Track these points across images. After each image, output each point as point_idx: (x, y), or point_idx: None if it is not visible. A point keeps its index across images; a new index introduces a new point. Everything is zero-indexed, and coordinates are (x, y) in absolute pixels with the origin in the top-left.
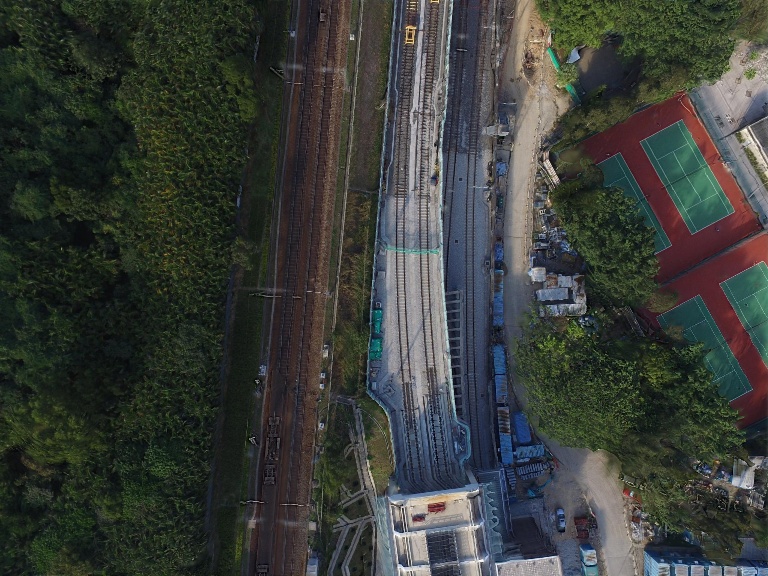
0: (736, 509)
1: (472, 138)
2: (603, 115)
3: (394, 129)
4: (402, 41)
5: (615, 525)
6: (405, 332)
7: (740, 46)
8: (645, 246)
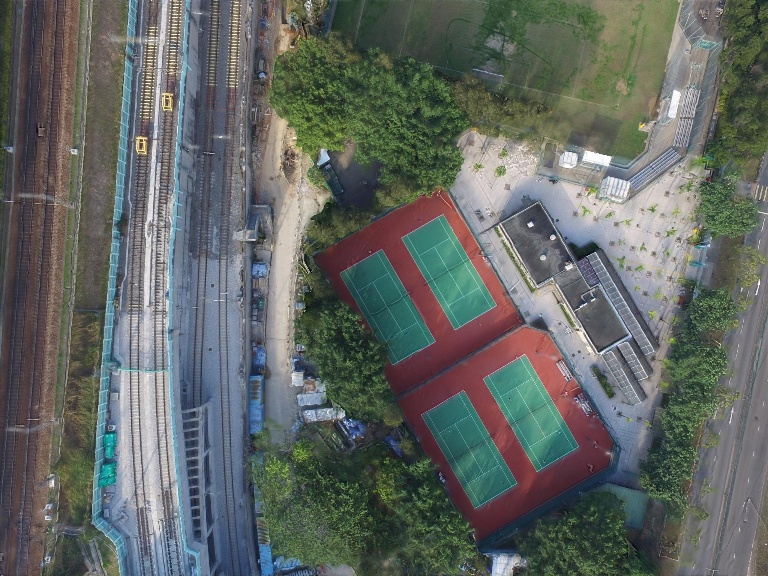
0: None
1: (222, 243)
2: (329, 229)
3: (128, 243)
4: (135, 151)
5: None
6: (139, 455)
7: (497, 140)
8: (365, 365)
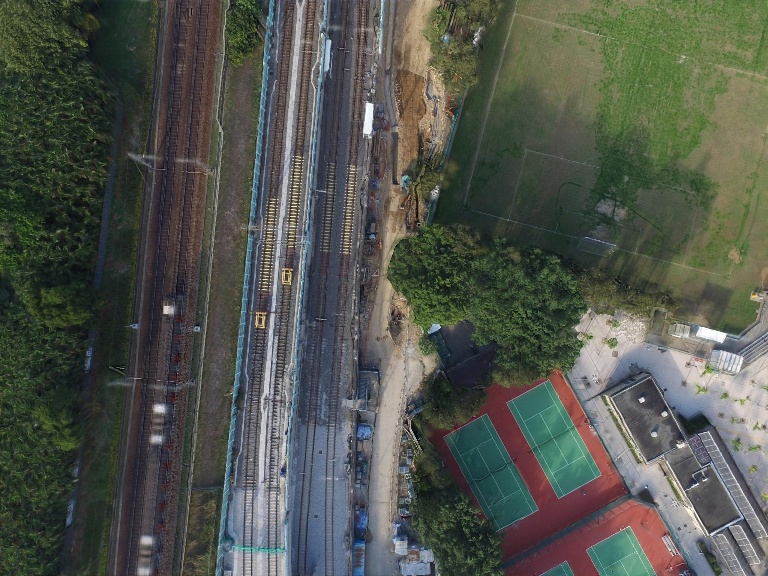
0: None
1: (331, 410)
2: (449, 417)
3: (244, 417)
4: (253, 324)
5: None
6: None
7: None
8: (486, 564)
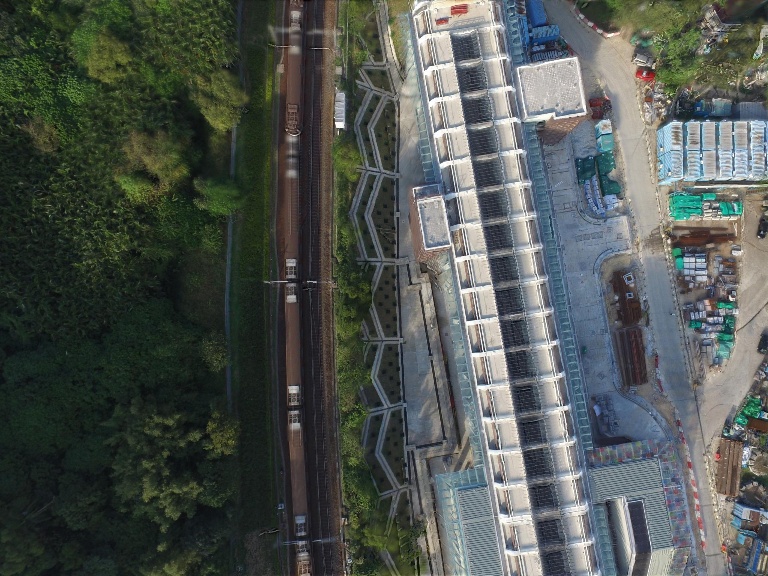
0: (745, 84)
1: None
2: None
3: None
4: None
5: (628, 109)
6: None
7: None
8: None
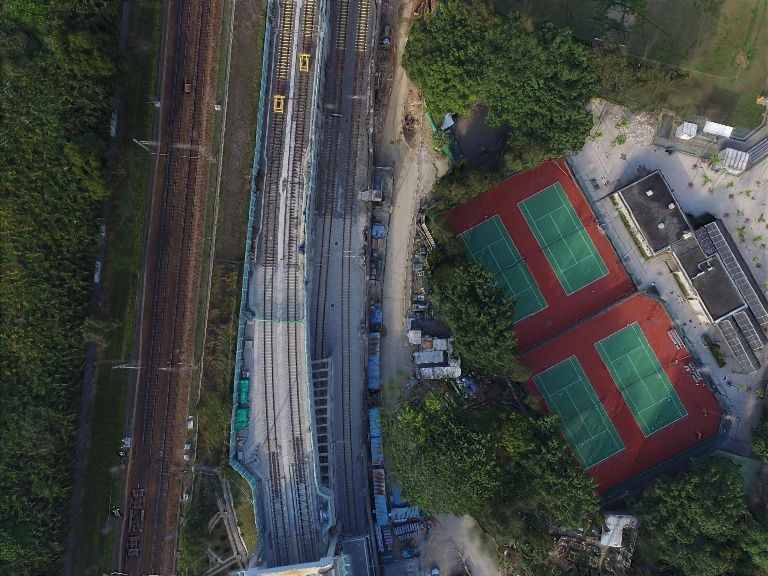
0: (607, 566)
1: (347, 203)
2: (463, 188)
3: (263, 198)
4: (272, 109)
5: None
6: (272, 401)
7: (615, 109)
8: (499, 320)
